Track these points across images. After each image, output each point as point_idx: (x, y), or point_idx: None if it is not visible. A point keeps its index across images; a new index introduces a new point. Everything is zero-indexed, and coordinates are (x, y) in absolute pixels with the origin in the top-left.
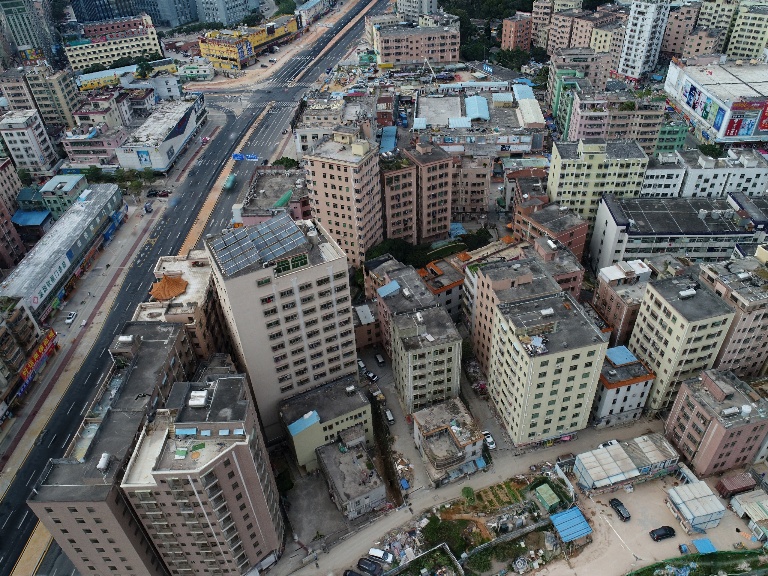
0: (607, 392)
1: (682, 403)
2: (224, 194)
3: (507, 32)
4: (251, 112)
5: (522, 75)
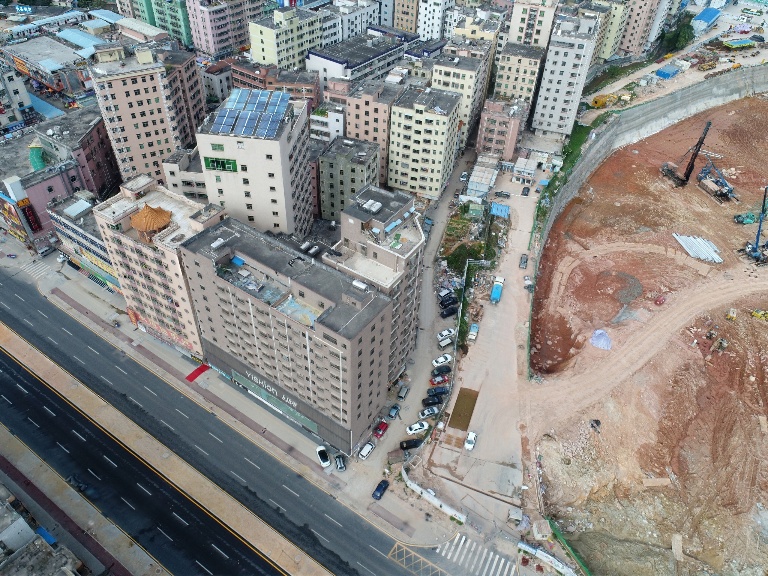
0: None
1: (485, 126)
2: None
3: None
4: None
5: (66, 8)
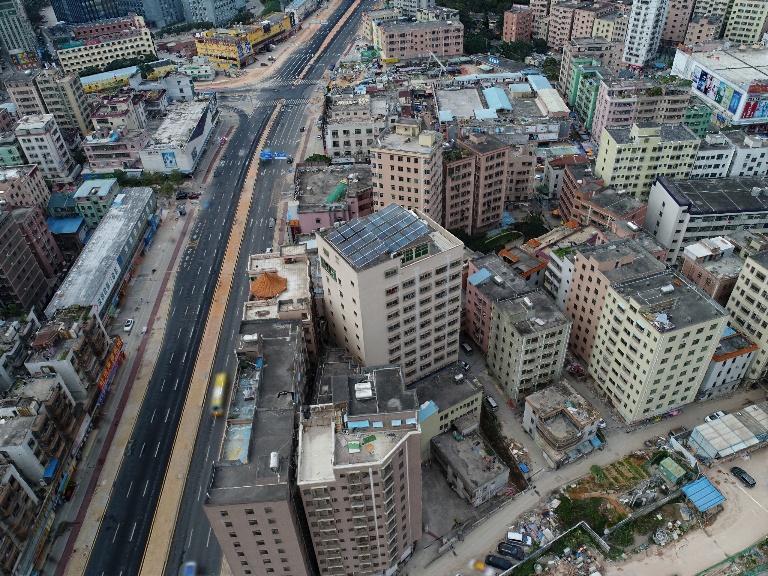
0: (715, 365)
1: None
2: (256, 193)
3: (508, 24)
4: (263, 111)
5: (528, 66)
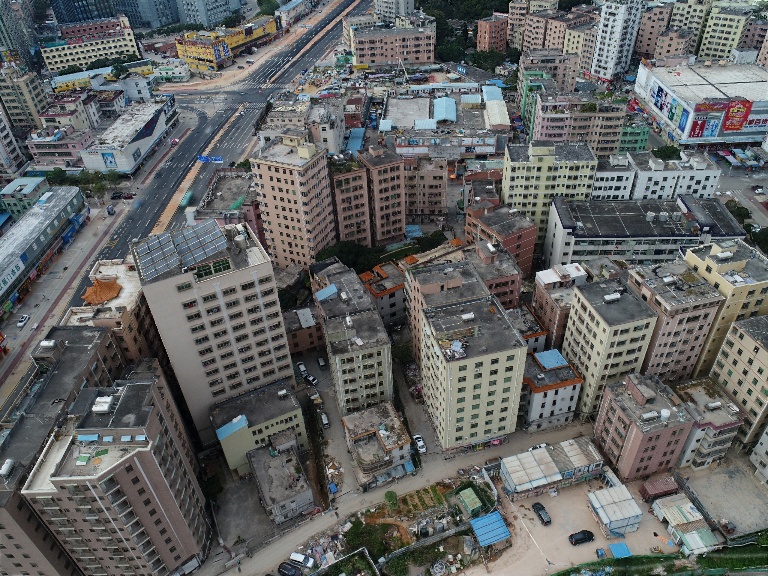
0: (534, 396)
1: (607, 407)
2: (188, 196)
3: (482, 33)
4: (223, 114)
5: (495, 76)
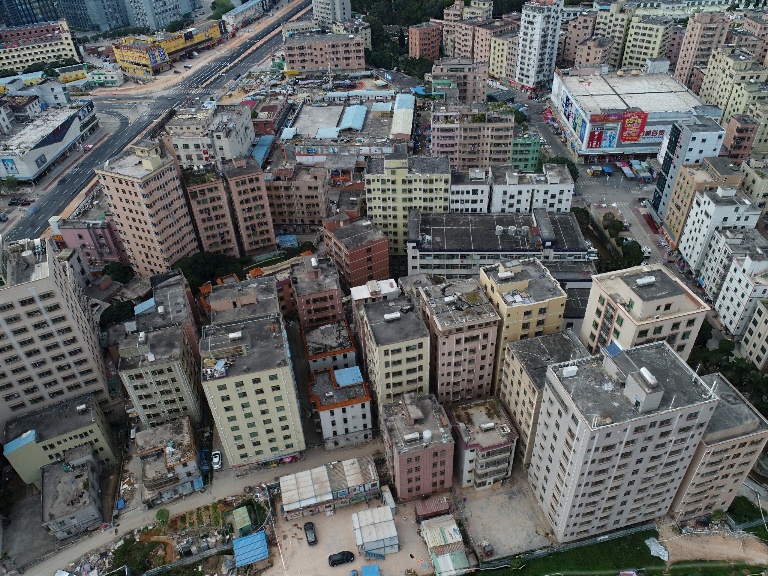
0: (320, 414)
1: None
2: None
3: (413, 40)
4: (145, 119)
5: (421, 83)
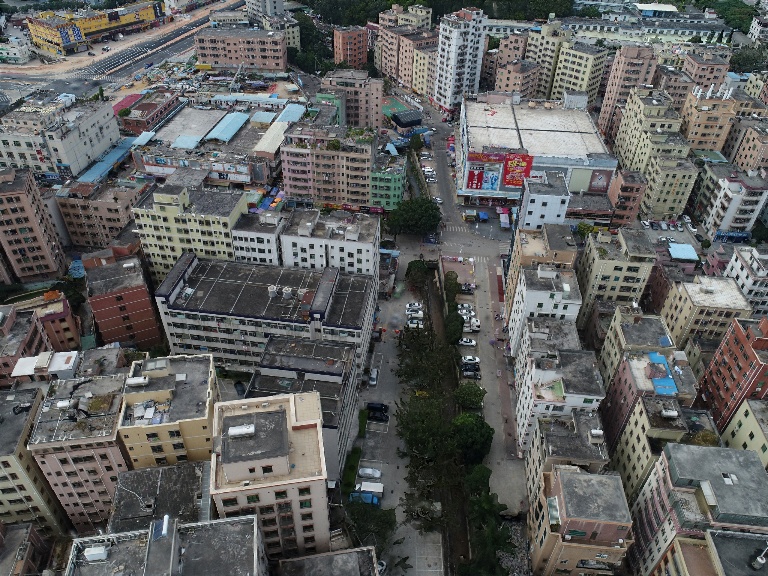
0: None
1: None
2: None
3: (337, 43)
4: None
5: None
